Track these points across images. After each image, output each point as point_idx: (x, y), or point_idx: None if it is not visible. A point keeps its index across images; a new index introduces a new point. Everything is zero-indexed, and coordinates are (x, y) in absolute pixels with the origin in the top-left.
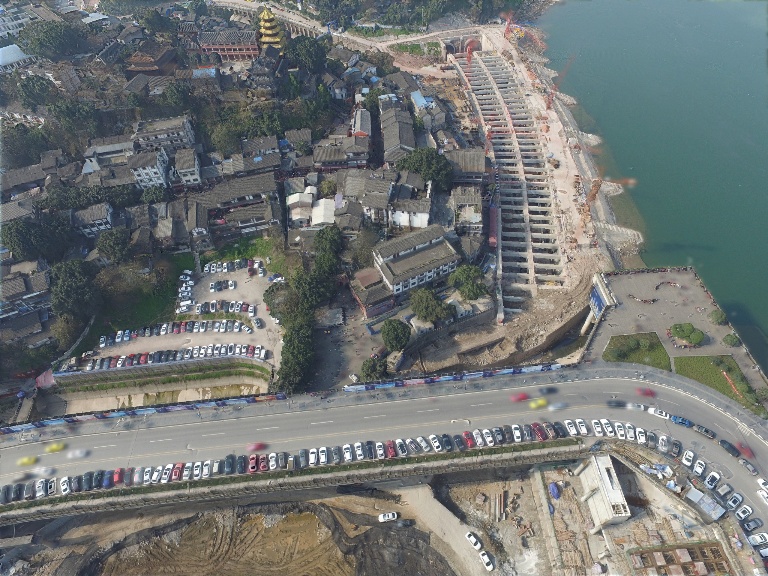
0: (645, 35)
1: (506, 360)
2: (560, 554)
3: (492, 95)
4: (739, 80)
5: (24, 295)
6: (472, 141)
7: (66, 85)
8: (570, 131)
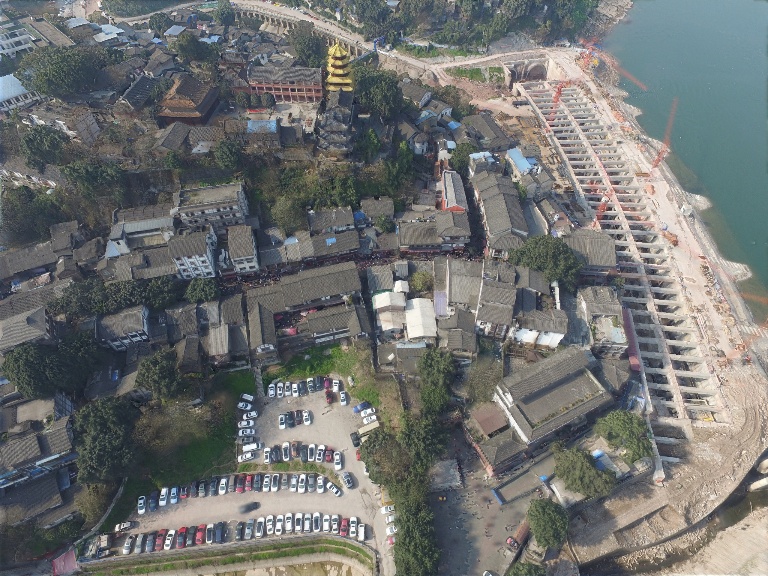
0: (729, 66)
1: (671, 536)
2: None
3: (577, 140)
4: None
5: (38, 460)
6: (569, 205)
7: (82, 135)
8: (678, 193)
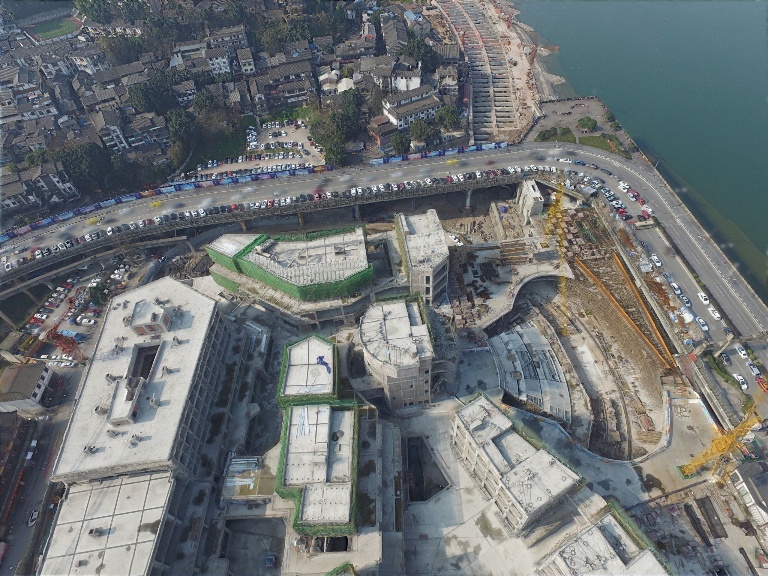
0: None
1: None
2: (505, 232)
3: (467, 25)
4: (662, 11)
5: (150, 128)
6: None
7: (152, 8)
8: (526, 45)
